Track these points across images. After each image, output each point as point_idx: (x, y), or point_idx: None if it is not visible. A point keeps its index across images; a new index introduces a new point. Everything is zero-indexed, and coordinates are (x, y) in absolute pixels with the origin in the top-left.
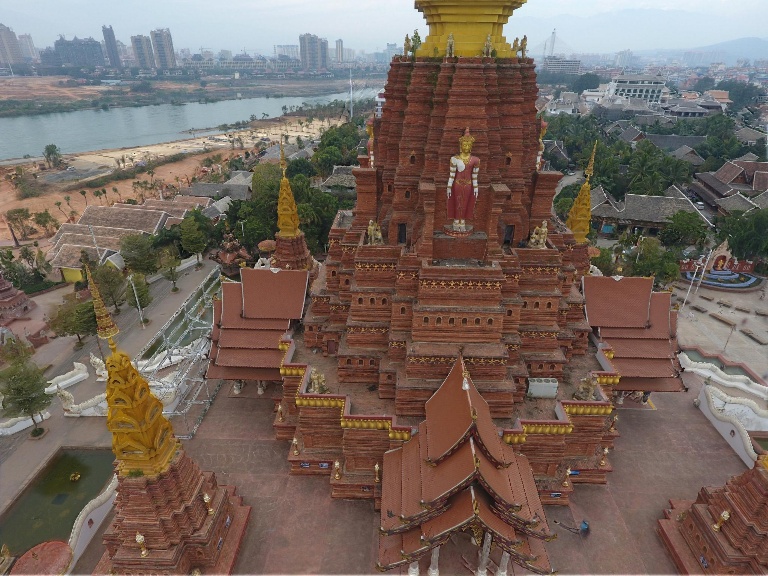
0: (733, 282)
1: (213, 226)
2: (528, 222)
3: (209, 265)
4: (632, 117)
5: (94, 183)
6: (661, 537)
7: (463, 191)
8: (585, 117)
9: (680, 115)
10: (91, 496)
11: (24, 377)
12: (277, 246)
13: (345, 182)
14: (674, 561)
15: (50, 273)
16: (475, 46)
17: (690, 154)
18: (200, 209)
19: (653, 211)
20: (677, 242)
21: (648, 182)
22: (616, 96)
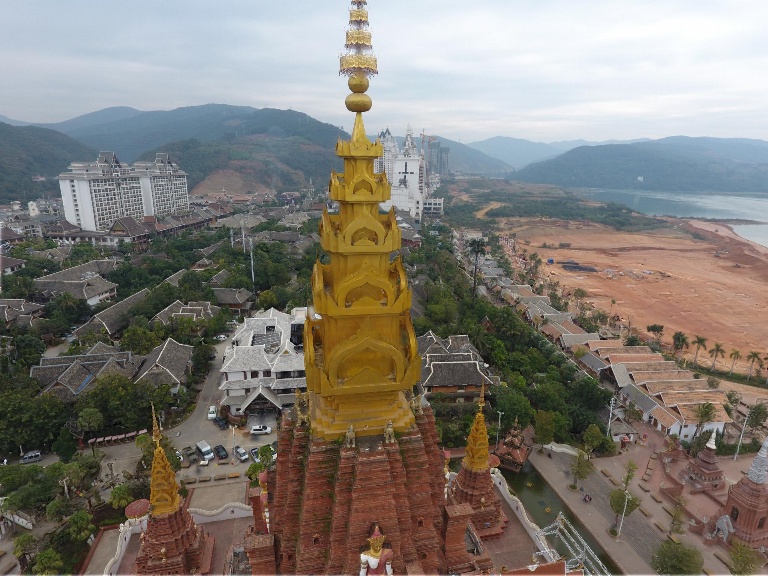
0: None
1: None
2: None
3: None
4: None
5: None
6: (210, 573)
7: None
8: None
9: None
10: None
11: (676, 553)
12: None
13: None
14: (212, 561)
15: None
16: None
17: None
18: None
19: None
20: None
21: None
22: None
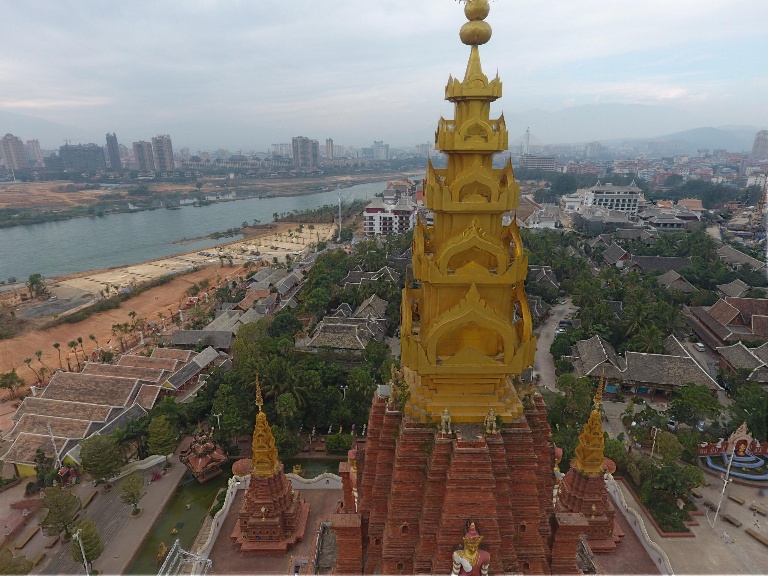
0: (760, 472)
1: (187, 414)
2: (549, 575)
3: (179, 464)
4: (614, 231)
5: (74, 318)
6: None
7: None
8: (569, 234)
9: (659, 226)
10: None
11: None
12: (252, 483)
13: (332, 342)
14: None
15: (0, 471)
16: (475, 409)
17: (679, 281)
18: (173, 397)
19: (657, 371)
20: (690, 417)
21: (647, 336)
22: (595, 208)
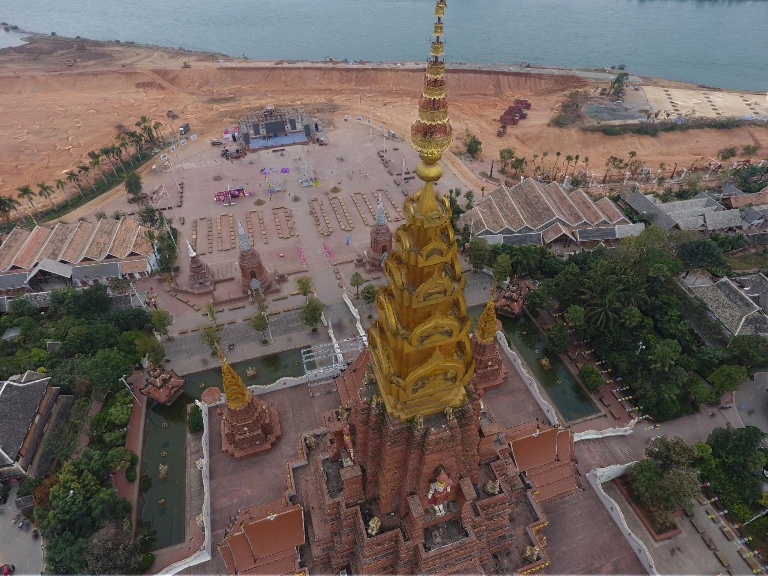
0: None
1: (534, 265)
2: None
3: None
4: None
5: (610, 130)
6: None
7: None
8: None
9: None
10: (289, 376)
11: (313, 309)
12: None
13: (714, 302)
14: None
15: None
16: None
17: None
18: (533, 248)
19: None
20: None
21: None
22: None
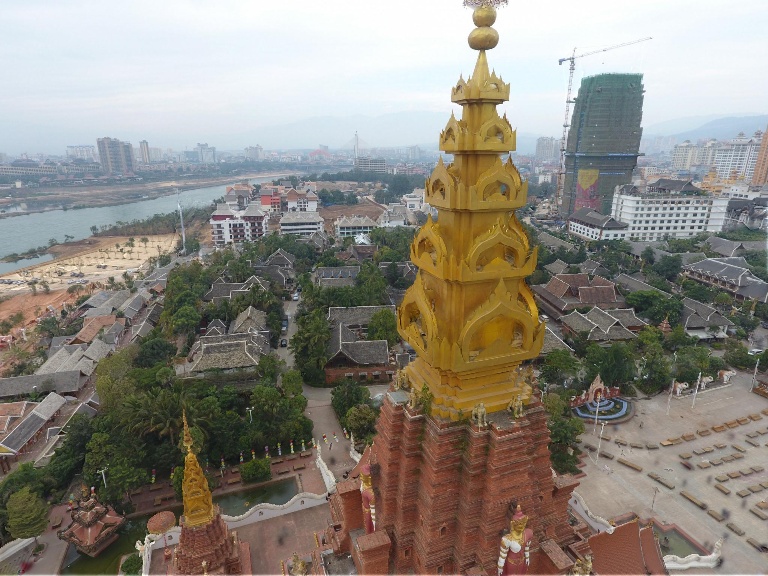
0: (613, 412)
1: (54, 479)
2: None
3: (55, 543)
4: None
5: None
6: None
7: (517, 569)
8: None
9: None
10: None
11: None
12: (184, 537)
13: (220, 363)
14: None
15: None
16: (497, 398)
17: None
18: (32, 462)
19: None
20: (558, 378)
21: None
22: None
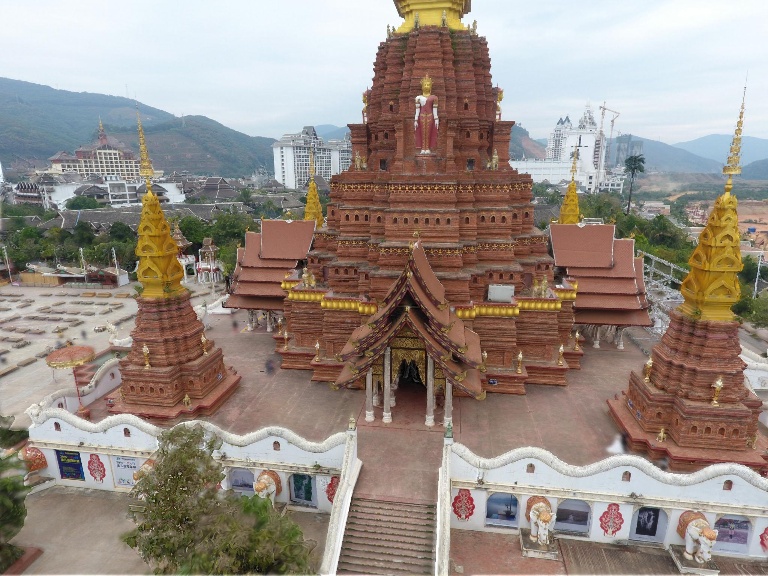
0: None
1: None
2: None
3: None
4: None
5: None
6: None
7: None
8: None
9: None
10: None
11: None
12: None
13: None
14: None
15: None
16: None
17: None
18: None
19: None
20: None
21: None
22: None
